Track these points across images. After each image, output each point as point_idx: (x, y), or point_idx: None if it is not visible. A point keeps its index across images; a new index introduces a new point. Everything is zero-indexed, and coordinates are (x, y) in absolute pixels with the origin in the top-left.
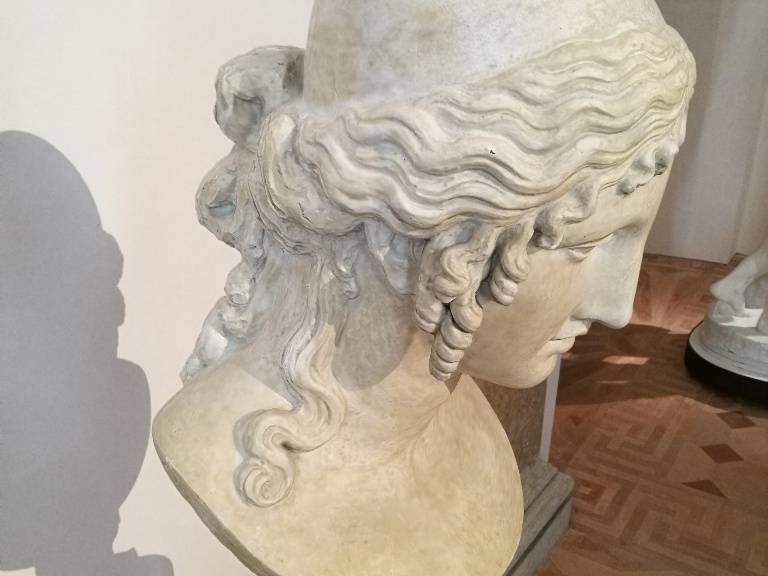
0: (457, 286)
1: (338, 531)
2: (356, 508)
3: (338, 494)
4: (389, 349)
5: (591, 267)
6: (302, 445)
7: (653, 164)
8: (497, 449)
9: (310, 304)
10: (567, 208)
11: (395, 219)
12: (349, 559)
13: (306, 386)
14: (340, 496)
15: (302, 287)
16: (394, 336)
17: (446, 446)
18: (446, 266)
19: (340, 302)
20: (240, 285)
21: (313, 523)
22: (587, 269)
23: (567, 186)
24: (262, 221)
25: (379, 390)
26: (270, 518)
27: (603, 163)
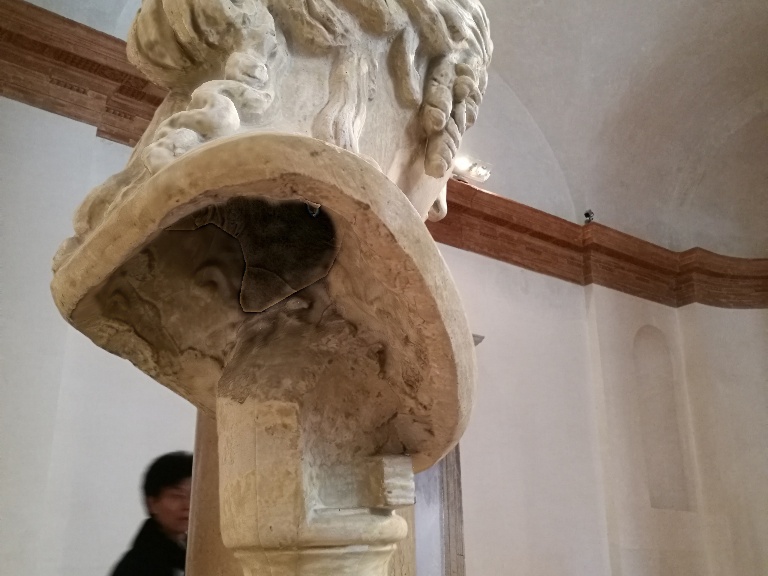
0: None
1: None
2: None
3: None
4: (384, 159)
5: None
6: None
7: None
8: None
9: (351, 87)
10: None
11: (445, 24)
12: None
13: None
14: None
15: (319, 84)
16: (388, 147)
17: None
18: (470, 67)
19: None
20: None
21: None
22: None
23: None
24: (305, 6)
25: None
26: None
27: None
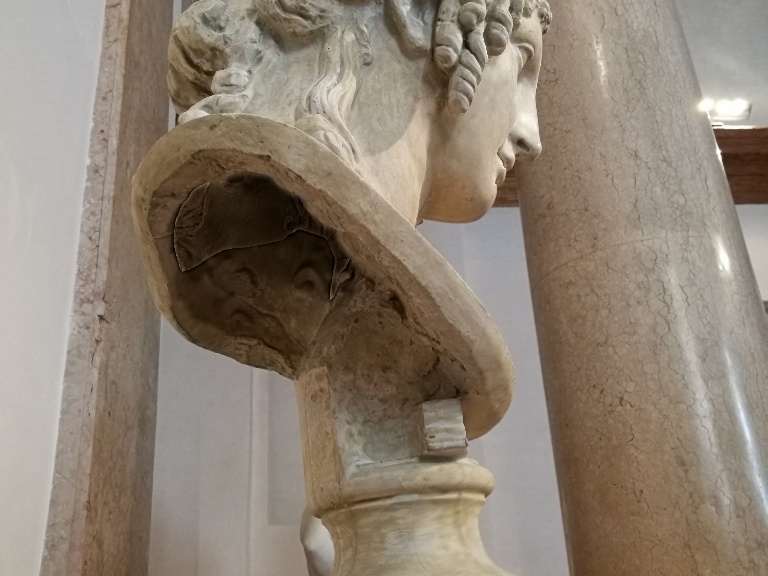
0: (482, 7)
1: None
2: None
3: None
4: (397, 115)
5: None
6: None
7: None
8: None
9: (333, 59)
10: None
11: None
12: None
13: (337, 120)
14: None
15: (308, 69)
16: (402, 102)
17: None
18: None
19: (359, 62)
20: (238, 71)
21: None
22: None
23: None
24: (278, 6)
25: (387, 159)
26: None
27: None
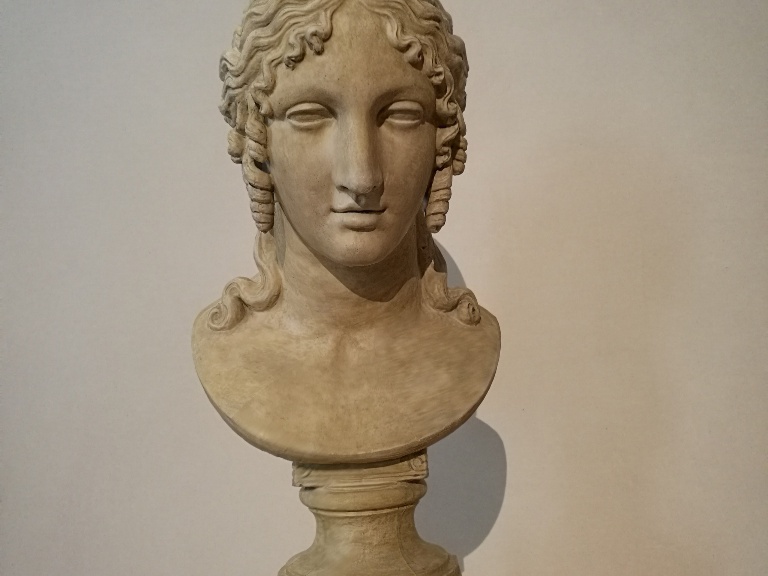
0: None
1: (244, 360)
2: (268, 355)
3: (262, 342)
4: None
5: (331, 142)
6: (244, 298)
7: (295, 41)
8: (449, 389)
9: None
10: (257, 81)
11: None
12: (237, 376)
13: None
14: (262, 344)
15: None
16: None
17: (386, 360)
18: None
19: None
20: None
21: (233, 349)
22: (327, 143)
23: (253, 66)
24: None
25: (286, 267)
26: (213, 337)
27: (262, 45)
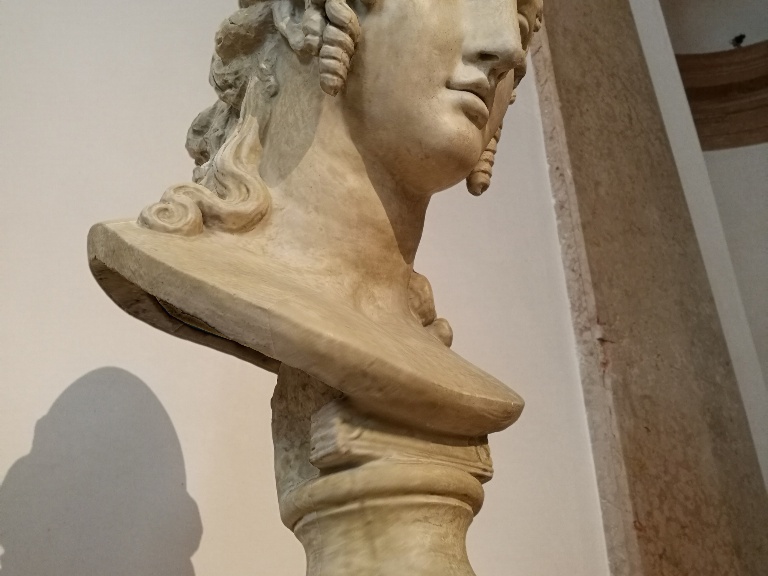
0: None
1: None
2: (265, 273)
3: None
4: (303, 125)
5: (466, 10)
6: (213, 204)
7: None
8: None
9: None
10: None
11: None
12: (236, 276)
13: (229, 171)
14: (249, 262)
15: None
16: (306, 110)
17: (411, 329)
18: None
19: (263, 100)
20: None
21: (207, 254)
22: None
23: None
24: (218, 90)
25: (299, 174)
26: (161, 237)
27: None
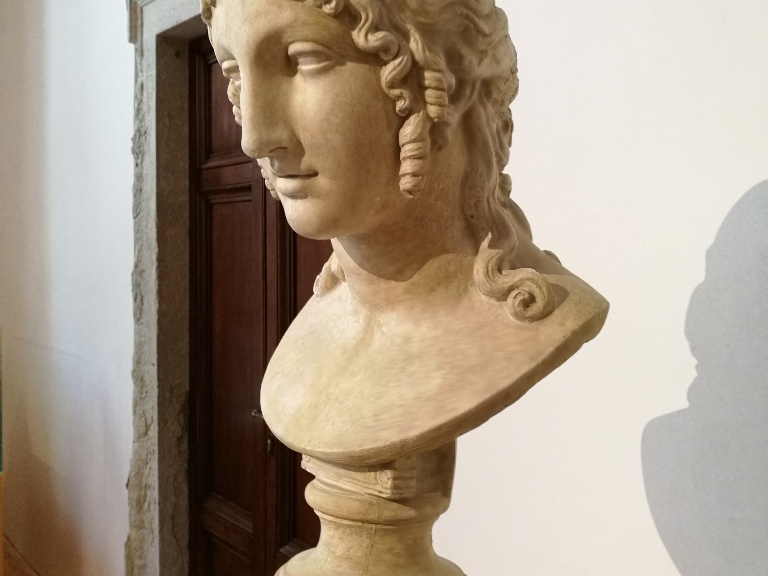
0: None
1: None
2: (323, 327)
3: None
4: None
5: None
6: None
7: None
8: (427, 398)
9: None
10: None
11: None
12: None
13: None
14: (327, 315)
15: None
16: None
17: (397, 351)
18: None
19: None
20: None
21: None
22: None
23: None
24: None
25: None
26: None
27: None
